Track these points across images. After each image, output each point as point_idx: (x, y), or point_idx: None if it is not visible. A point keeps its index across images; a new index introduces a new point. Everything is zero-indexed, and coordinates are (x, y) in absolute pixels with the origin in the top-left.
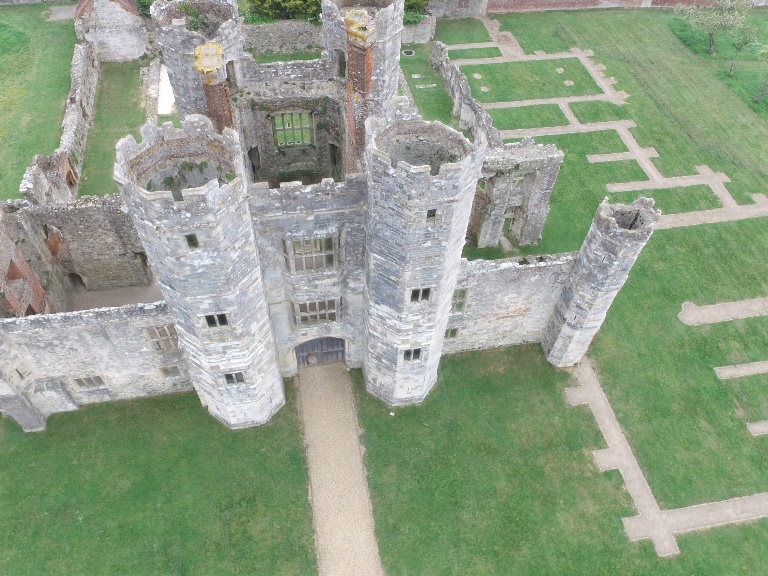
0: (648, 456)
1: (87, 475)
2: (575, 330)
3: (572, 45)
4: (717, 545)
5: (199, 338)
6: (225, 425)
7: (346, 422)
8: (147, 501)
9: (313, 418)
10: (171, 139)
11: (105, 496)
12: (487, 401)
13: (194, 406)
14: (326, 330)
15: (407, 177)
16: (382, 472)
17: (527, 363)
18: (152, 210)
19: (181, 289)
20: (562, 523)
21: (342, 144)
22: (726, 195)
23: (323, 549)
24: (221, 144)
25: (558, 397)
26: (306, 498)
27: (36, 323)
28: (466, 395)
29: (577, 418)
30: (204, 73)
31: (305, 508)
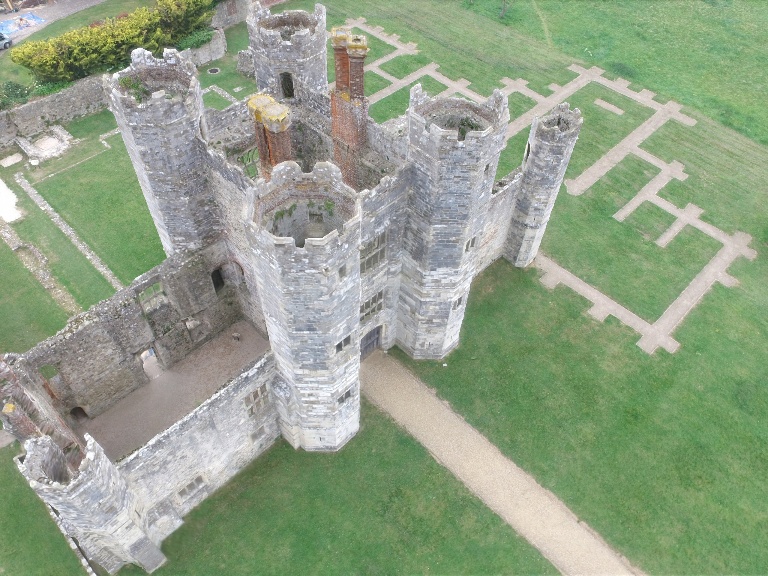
0: (620, 295)
1: (244, 568)
2: (537, 229)
3: (344, 18)
4: (695, 327)
5: (329, 369)
6: (327, 452)
7: (417, 391)
8: (317, 551)
9: (390, 404)
10: (264, 195)
11: (276, 573)
12: (499, 317)
13: (287, 454)
14: (376, 322)
15: (477, 143)
16: (473, 410)
17: (504, 276)
18: (322, 255)
19: (325, 326)
20: (607, 369)
21: (312, 157)
22: (534, 94)
23: (478, 490)
24: (311, 181)
25: (540, 288)
26: (436, 464)
27: (156, 446)
28: (483, 321)
29: (562, 295)
30: (279, 122)
31: (442, 471)
